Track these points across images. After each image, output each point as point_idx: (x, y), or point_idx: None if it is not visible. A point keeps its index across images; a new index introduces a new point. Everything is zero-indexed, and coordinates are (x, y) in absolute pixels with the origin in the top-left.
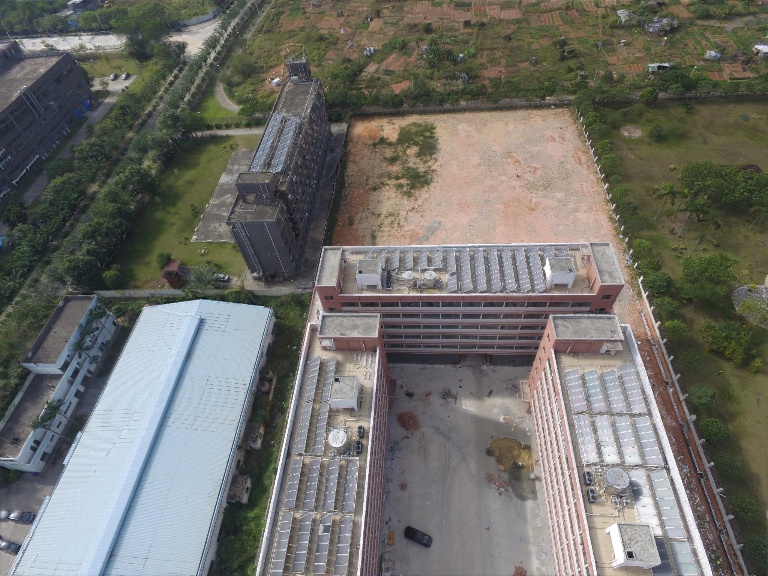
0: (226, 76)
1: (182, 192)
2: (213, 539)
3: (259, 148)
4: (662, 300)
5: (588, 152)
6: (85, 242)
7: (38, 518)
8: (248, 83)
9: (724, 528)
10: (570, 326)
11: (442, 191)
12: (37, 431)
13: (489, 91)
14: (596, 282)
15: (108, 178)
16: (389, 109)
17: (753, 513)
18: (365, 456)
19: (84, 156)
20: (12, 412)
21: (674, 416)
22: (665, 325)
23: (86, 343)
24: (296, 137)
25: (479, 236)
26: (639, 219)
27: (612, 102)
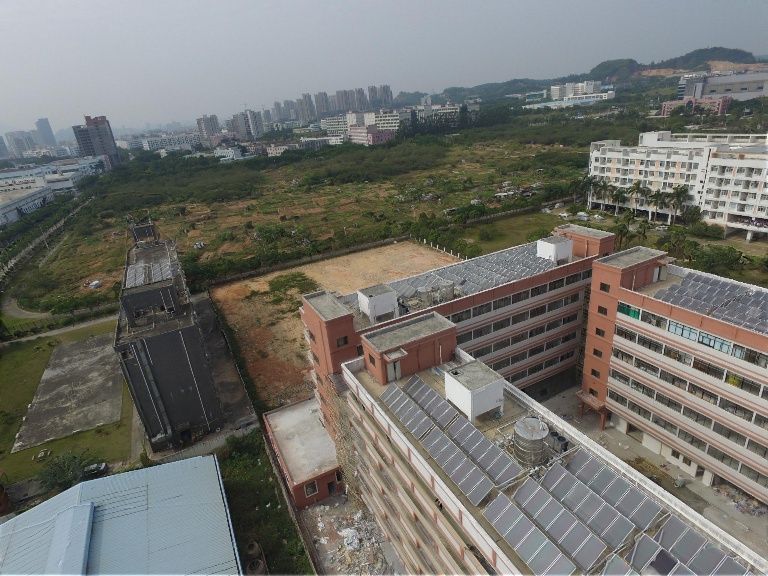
0: (21, 291)
1: None
2: None
3: None
4: None
5: (448, 255)
6: None
7: None
8: (55, 293)
9: None
10: (617, 263)
11: None
12: None
13: (336, 242)
14: (590, 245)
15: None
16: (247, 272)
17: None
18: None
19: None
20: None
21: None
22: None
23: None
24: (173, 272)
25: None
26: None
27: None
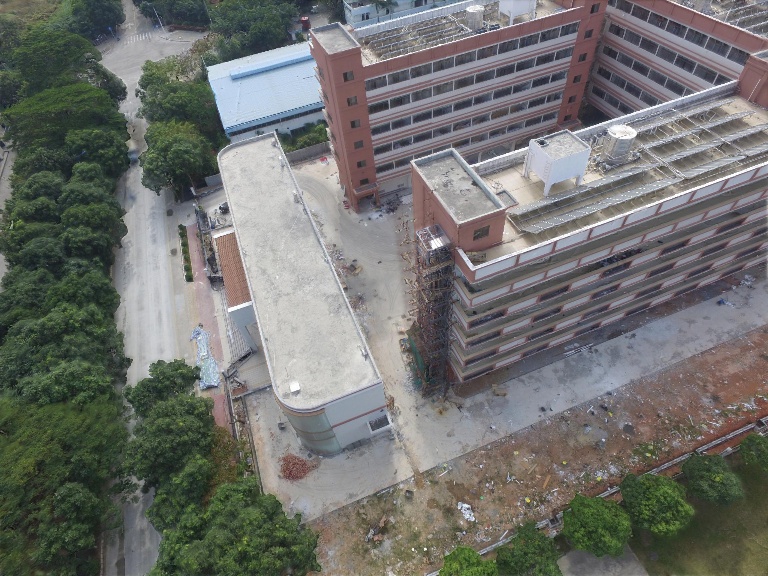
0: None
1: None
2: None
3: None
4: None
5: None
6: None
7: None
8: None
9: None
10: None
11: None
12: (373, 8)
13: None
14: None
15: None
16: None
17: (759, 459)
18: None
19: None
20: None
21: None
22: None
23: None
24: None
25: None
26: None
27: None
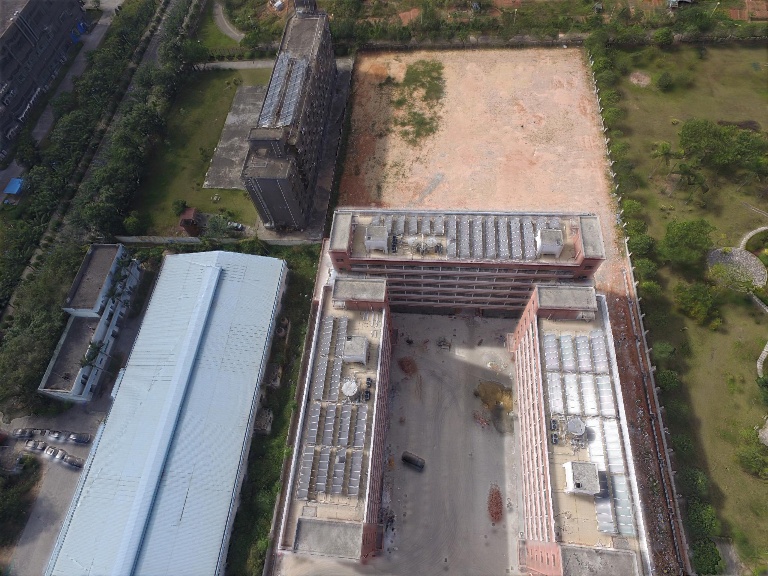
0: None
1: (189, 133)
2: (245, 459)
3: (267, 96)
4: (643, 262)
5: (595, 101)
6: (102, 188)
7: (97, 439)
8: (248, 6)
9: (664, 458)
10: (553, 296)
11: (447, 141)
12: (85, 368)
13: (501, 26)
14: (581, 254)
15: (113, 115)
16: (396, 44)
17: (688, 448)
18: (372, 402)
19: (87, 92)
20: (60, 350)
21: (638, 366)
22: (642, 285)
23: (117, 290)
24: (303, 85)
25: (480, 190)
26: (635, 177)
27: (626, 43)
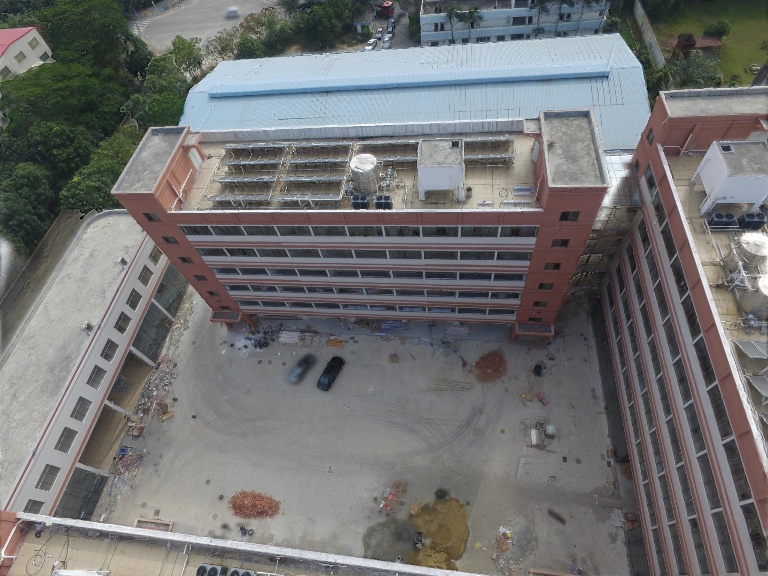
0: None
1: None
2: None
3: None
4: None
5: None
6: None
7: None
8: None
9: None
10: None
11: None
12: None
13: None
14: None
15: None
16: None
17: None
18: None
19: None
20: None
21: None
22: None
23: (550, 4)
24: None
25: None
26: None
27: None
